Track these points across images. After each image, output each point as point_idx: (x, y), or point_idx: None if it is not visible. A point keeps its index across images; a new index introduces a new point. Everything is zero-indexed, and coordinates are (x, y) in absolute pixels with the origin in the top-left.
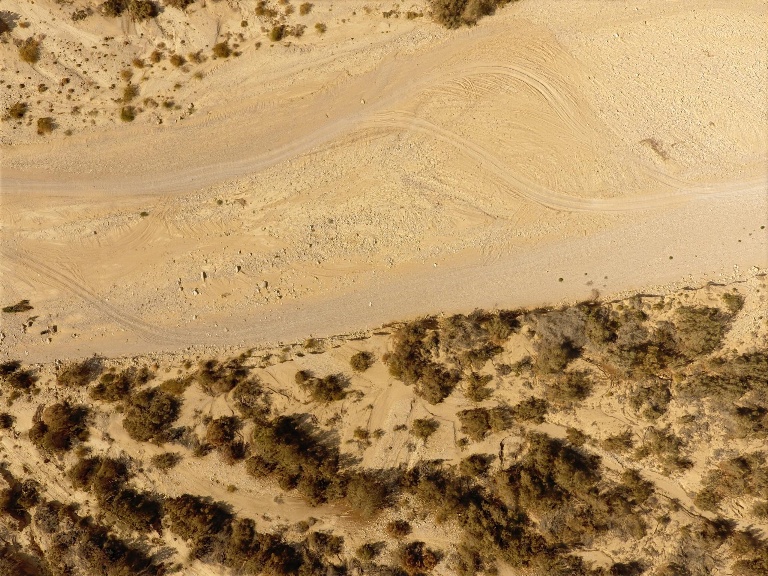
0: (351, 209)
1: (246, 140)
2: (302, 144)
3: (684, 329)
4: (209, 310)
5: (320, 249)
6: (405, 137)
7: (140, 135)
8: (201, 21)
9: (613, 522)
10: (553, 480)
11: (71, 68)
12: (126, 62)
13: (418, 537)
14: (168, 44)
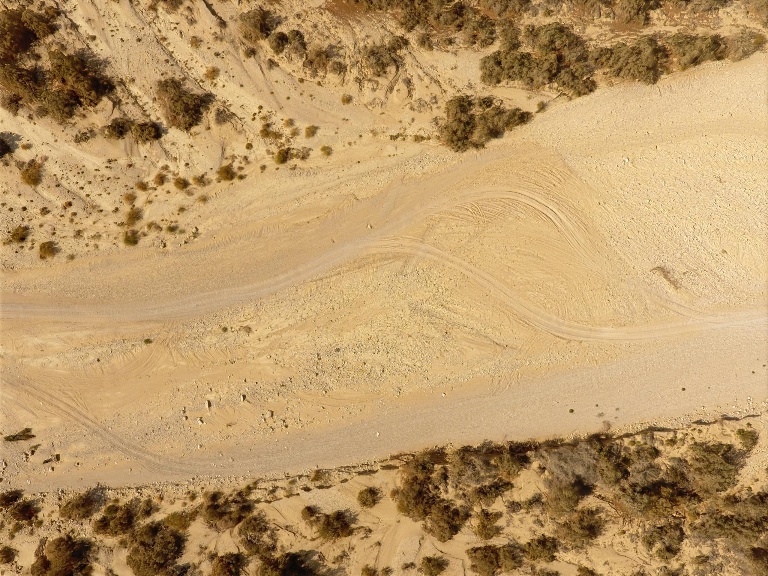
0: (358, 337)
1: (251, 265)
2: (308, 270)
3: (698, 468)
4: (214, 439)
5: (326, 378)
6: (412, 263)
7: (144, 260)
8: (205, 144)
9: None
10: None
11: (74, 191)
12: (129, 185)
13: None
14: (172, 167)
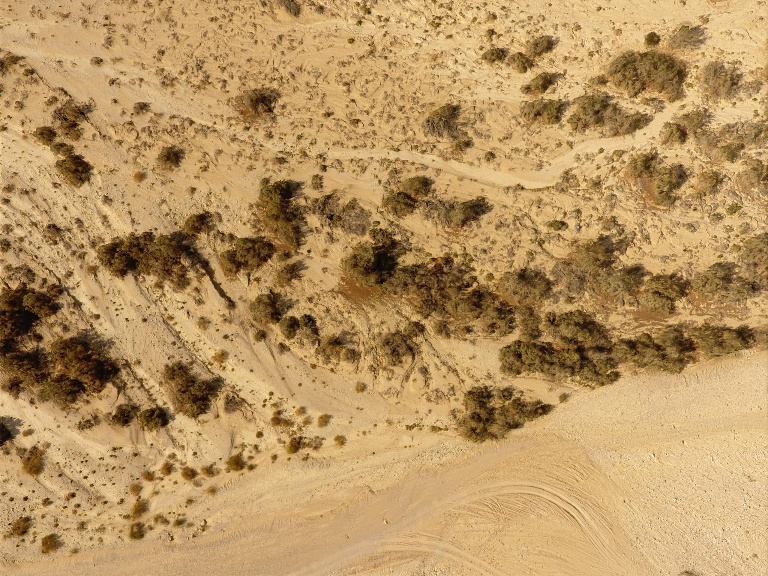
0: None
1: (262, 562)
2: (321, 567)
3: None
4: None
5: None
6: (430, 563)
7: (150, 554)
8: (214, 432)
9: None
10: None
11: (77, 480)
12: (135, 475)
13: None
14: (179, 455)
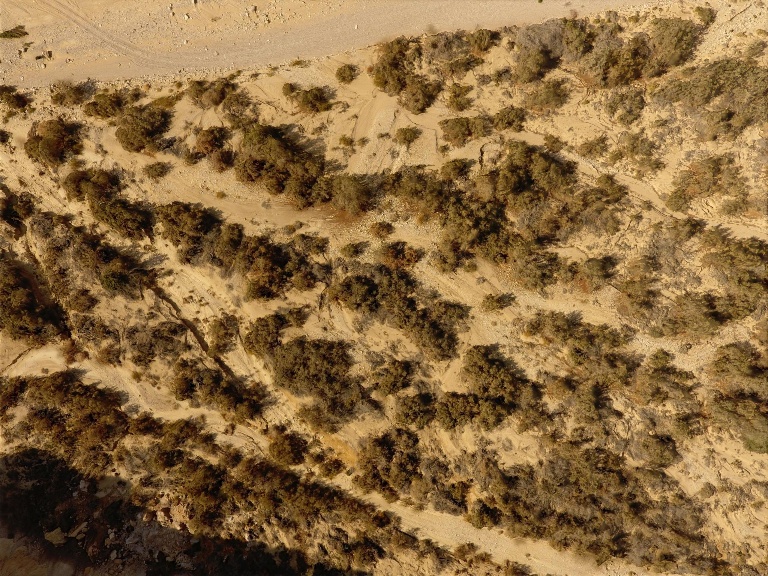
0: None
1: None
2: None
3: (658, 35)
4: (200, 35)
5: None
6: None
7: None
8: None
9: (588, 219)
10: (530, 177)
11: None
12: None
13: (400, 236)
14: None
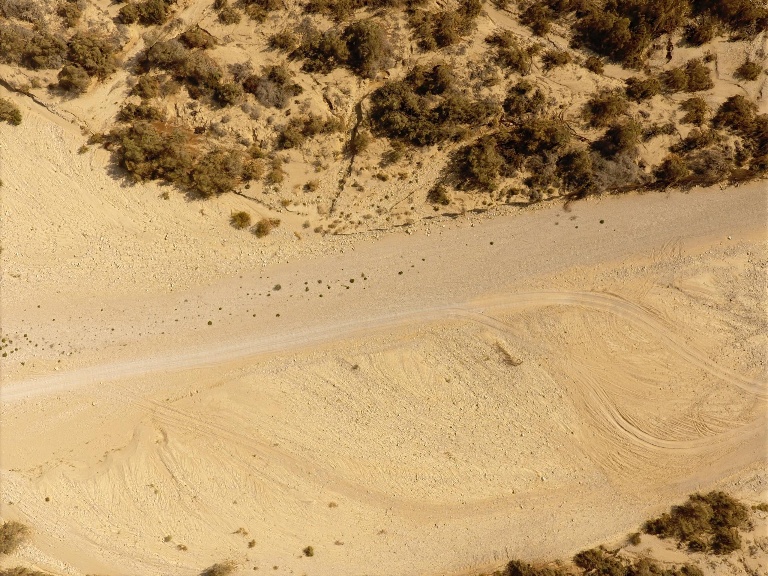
0: None
1: None
2: None
3: None
4: None
5: None
6: (767, 373)
7: None
8: None
9: None
10: None
11: None
12: None
13: None
14: None
